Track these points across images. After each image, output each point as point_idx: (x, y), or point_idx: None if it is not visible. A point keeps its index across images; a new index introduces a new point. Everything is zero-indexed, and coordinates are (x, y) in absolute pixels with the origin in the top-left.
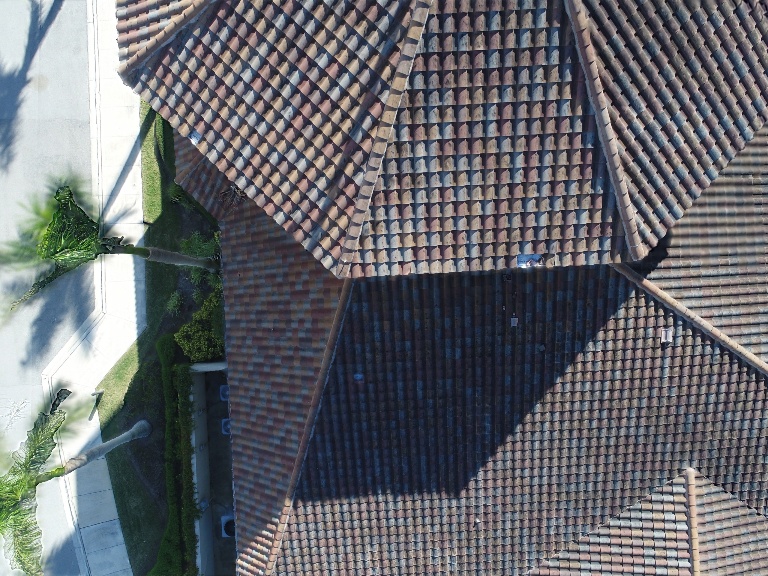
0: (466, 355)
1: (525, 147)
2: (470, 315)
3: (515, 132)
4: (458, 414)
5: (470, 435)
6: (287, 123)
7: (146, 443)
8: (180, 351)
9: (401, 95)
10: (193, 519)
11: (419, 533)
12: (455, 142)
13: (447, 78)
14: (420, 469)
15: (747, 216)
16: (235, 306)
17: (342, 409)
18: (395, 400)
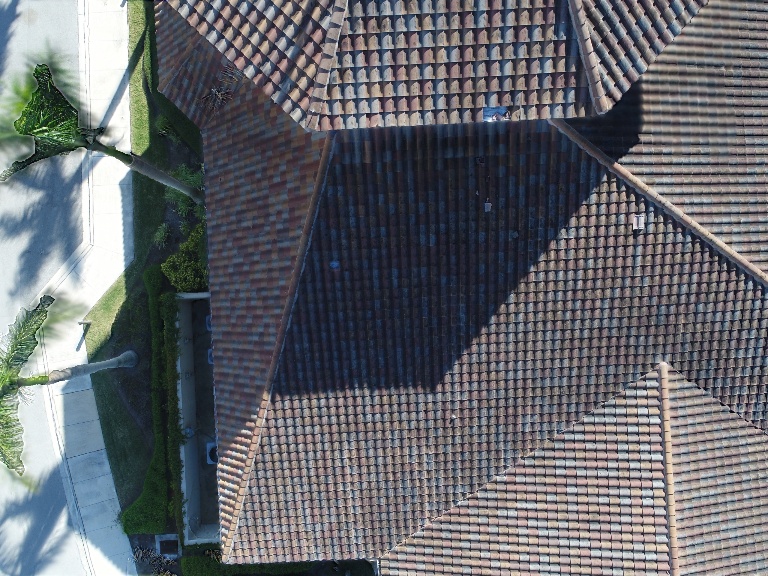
0: (440, 242)
1: None
2: (444, 200)
3: None
4: (433, 304)
5: (445, 326)
6: None
7: (133, 373)
8: (167, 282)
9: None
10: (178, 444)
11: (396, 429)
12: None
13: None
14: (396, 362)
15: (719, 107)
16: (216, 211)
17: (318, 298)
18: (371, 289)
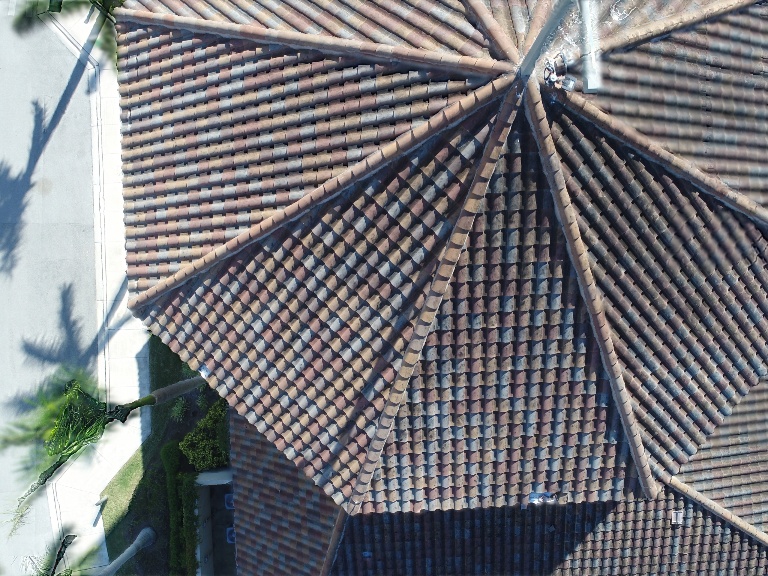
0: (475, 535)
1: (538, 405)
2: None
3: (529, 393)
4: None
5: None
6: (298, 373)
7: (151, 550)
8: (185, 458)
9: (414, 366)
10: None
11: None
12: (468, 402)
13: (461, 351)
14: None
15: (758, 393)
16: (242, 456)
17: None
18: (404, 575)
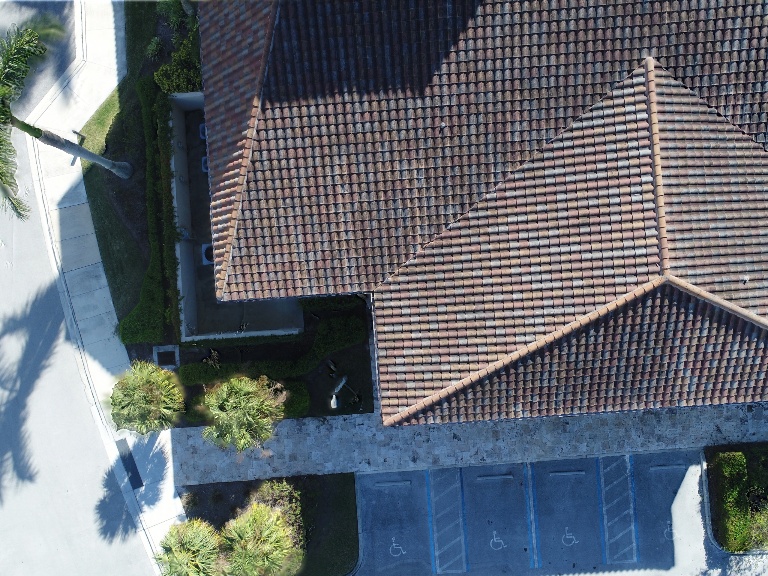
0: None
1: None
2: None
3: None
4: None
5: (432, 19)
6: None
7: (128, 186)
8: None
9: None
10: (173, 242)
11: (386, 140)
12: None
13: None
14: (384, 62)
15: None
16: None
17: None
18: None
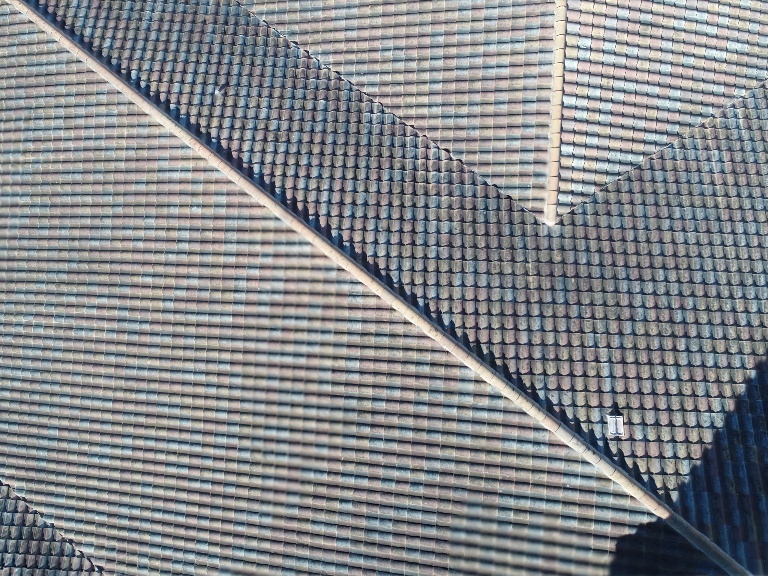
0: None
1: None
2: None
3: None
4: None
5: None
6: None
7: None
8: None
9: None
10: None
11: None
12: None
13: None
14: None
15: (474, 571)
16: None
17: None
18: None
